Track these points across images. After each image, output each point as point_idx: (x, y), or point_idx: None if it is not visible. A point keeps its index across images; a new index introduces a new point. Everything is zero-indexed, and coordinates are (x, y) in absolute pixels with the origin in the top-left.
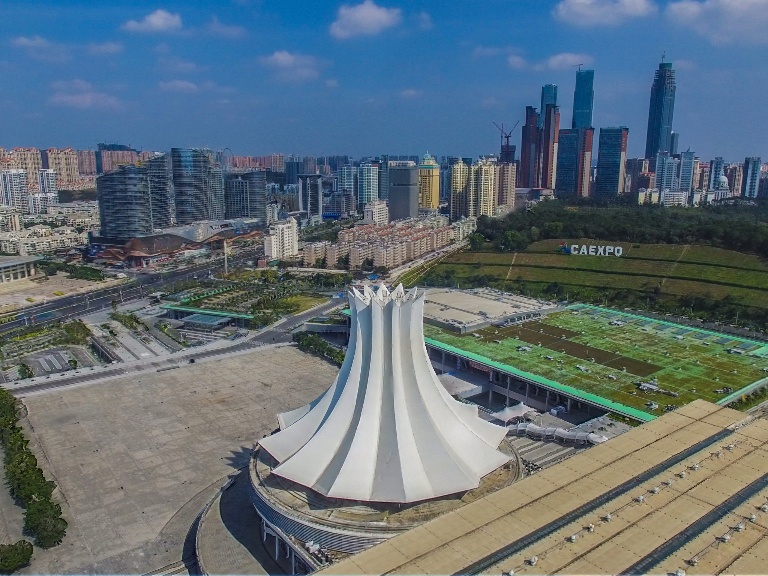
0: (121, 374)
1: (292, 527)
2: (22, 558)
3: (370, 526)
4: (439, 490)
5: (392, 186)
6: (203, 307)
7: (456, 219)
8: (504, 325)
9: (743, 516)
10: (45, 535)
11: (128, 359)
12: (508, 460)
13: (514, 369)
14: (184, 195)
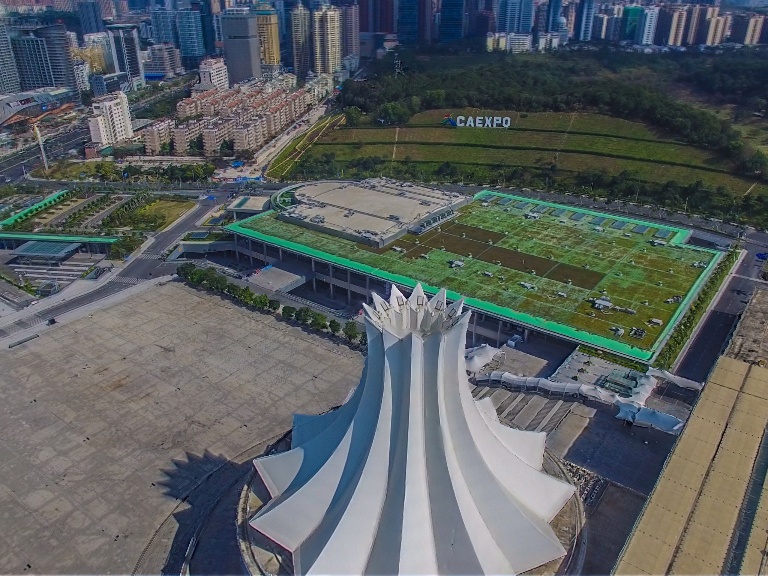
0: None
1: None
2: None
3: None
4: (518, 564)
5: (227, 39)
6: (37, 231)
7: (305, 76)
8: (422, 231)
9: None
10: None
11: None
12: (573, 492)
13: (458, 295)
14: None
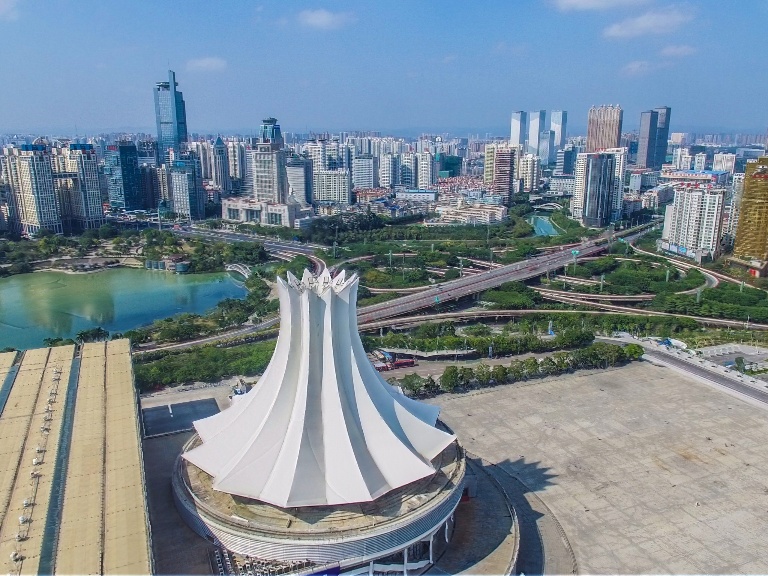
0: (766, 402)
1: None
2: None
3: None
4: None
5: None
6: None
7: None
8: None
9: None
10: None
11: None
12: None
13: None
14: None
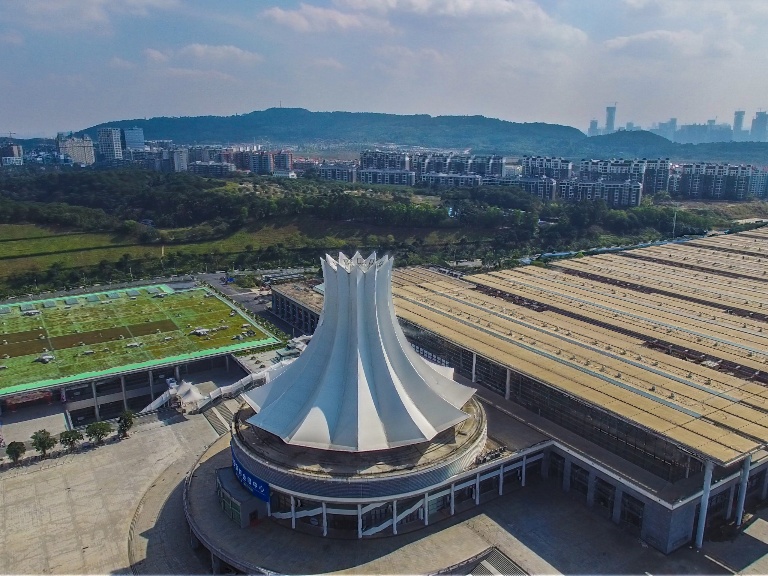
0: None
1: (465, 461)
2: None
3: None
4: None
5: None
6: None
7: None
8: None
9: None
10: None
11: None
12: None
13: (96, 372)
14: None
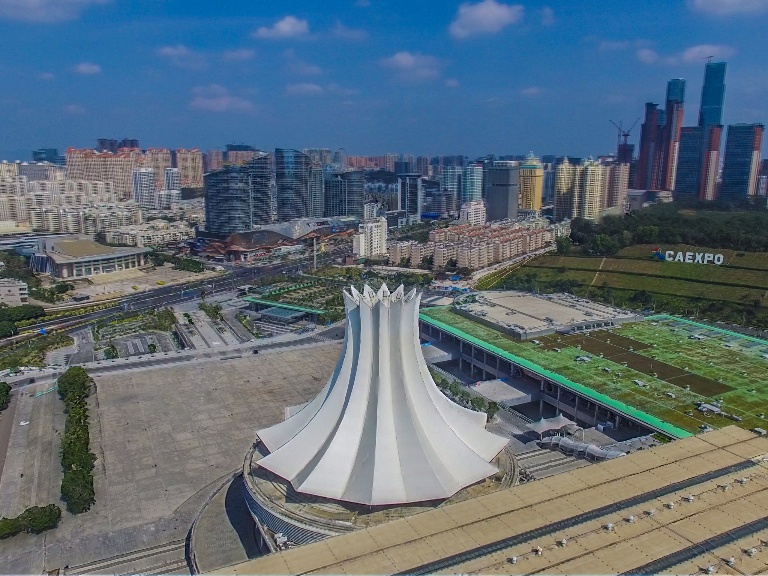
0: (190, 360)
1: (266, 517)
2: (48, 520)
3: (335, 524)
4: (412, 496)
5: (491, 186)
6: (281, 301)
7: (557, 221)
8: (569, 333)
9: (722, 558)
10: (73, 502)
11: (200, 347)
12: (495, 472)
13: (565, 379)
14: (285, 193)
